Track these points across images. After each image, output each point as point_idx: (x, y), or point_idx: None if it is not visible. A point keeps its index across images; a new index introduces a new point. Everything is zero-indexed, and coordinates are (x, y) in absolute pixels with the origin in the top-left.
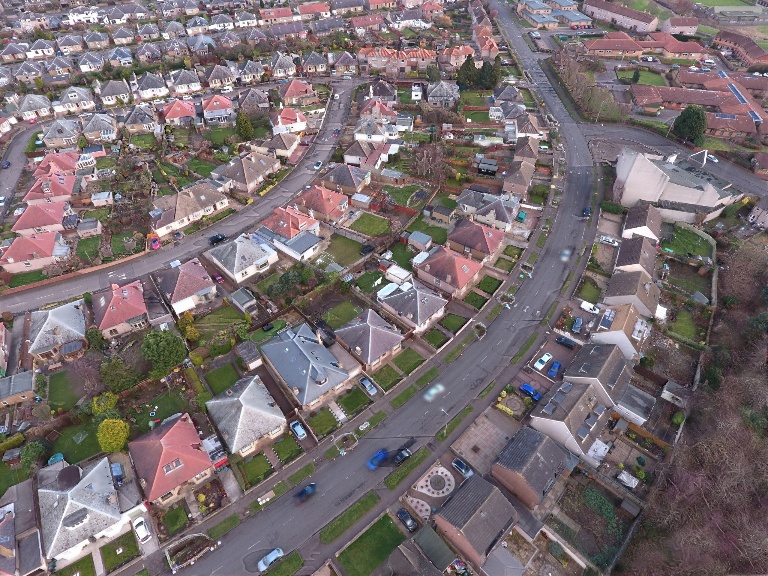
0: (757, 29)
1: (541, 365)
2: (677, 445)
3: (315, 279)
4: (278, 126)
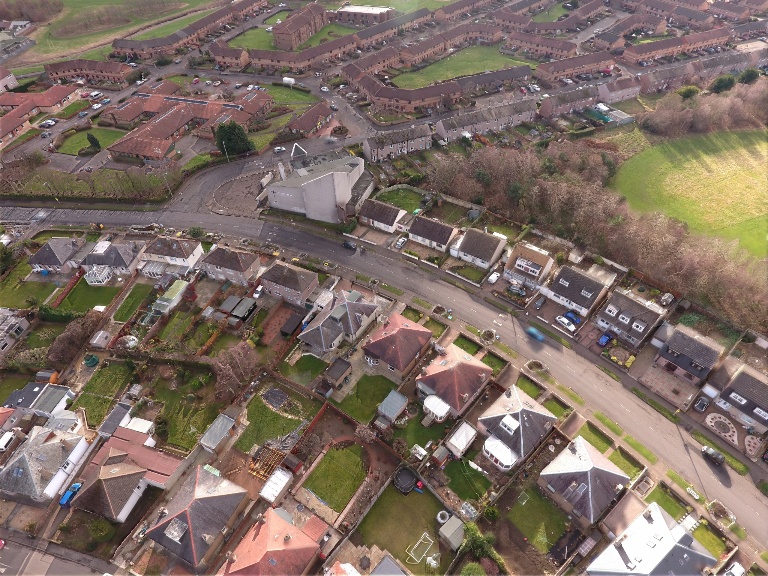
0: (37, 52)
1: (572, 326)
2: (651, 260)
3: (487, 560)
4: None
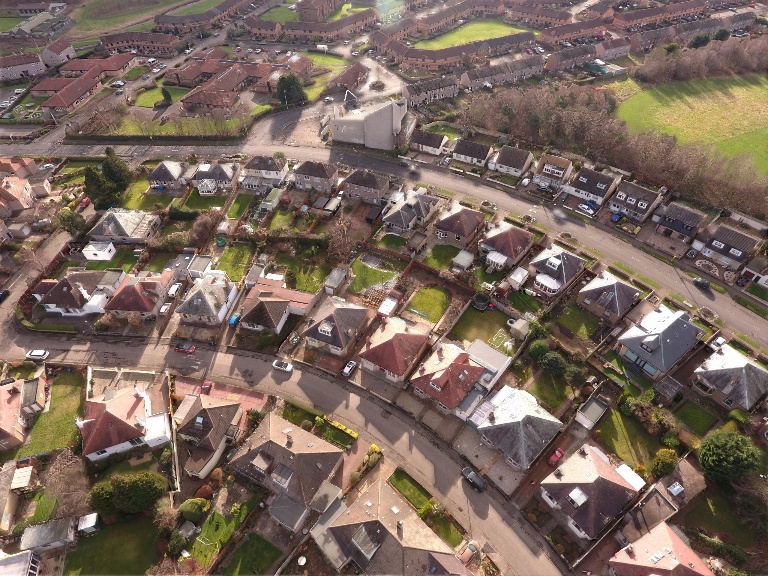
0: (80, 30)
1: (591, 210)
2: None
3: None
4: (145, 429)
